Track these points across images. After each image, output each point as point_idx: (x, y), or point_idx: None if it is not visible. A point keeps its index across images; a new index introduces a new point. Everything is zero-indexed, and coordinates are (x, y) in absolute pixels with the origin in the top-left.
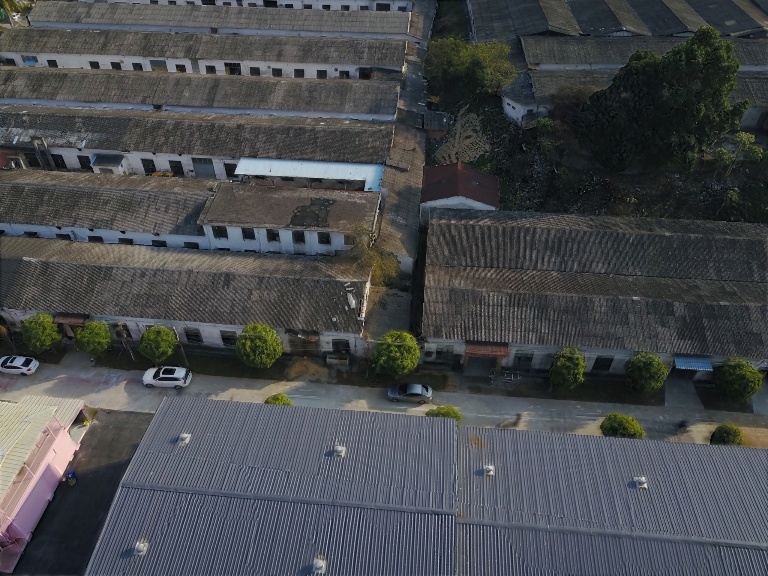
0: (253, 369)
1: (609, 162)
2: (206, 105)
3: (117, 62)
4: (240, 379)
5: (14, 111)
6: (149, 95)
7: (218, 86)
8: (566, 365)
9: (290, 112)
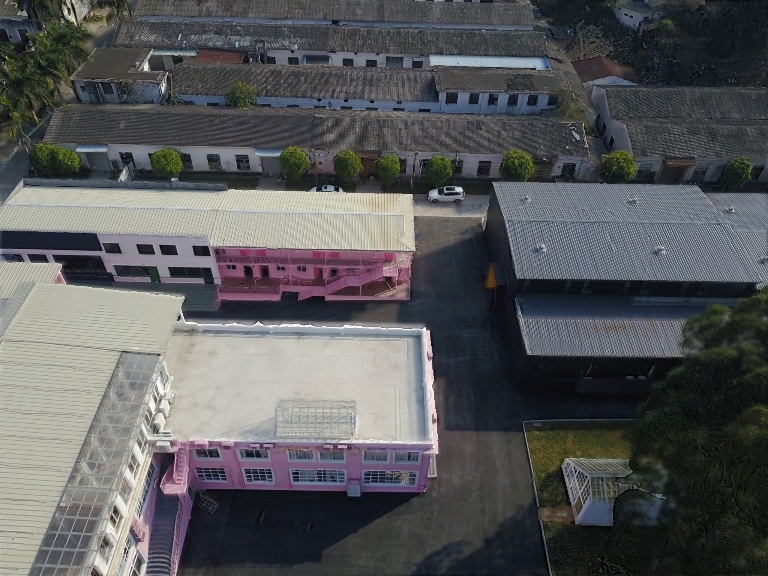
0: None
1: (719, 49)
2: (378, 20)
3: None
4: None
5: None
6: (328, 13)
7: (384, 5)
8: (741, 166)
9: (448, 25)
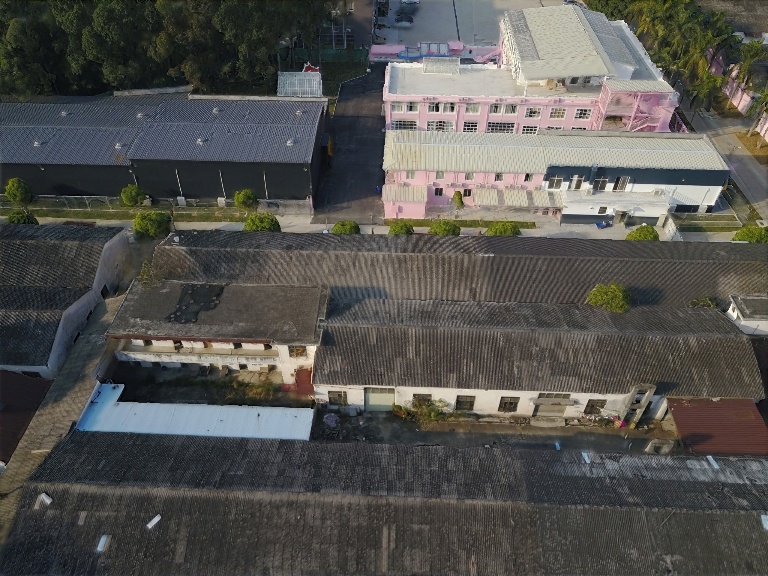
0: None
1: None
2: None
3: None
4: None
5: None
6: None
7: None
8: None
9: None
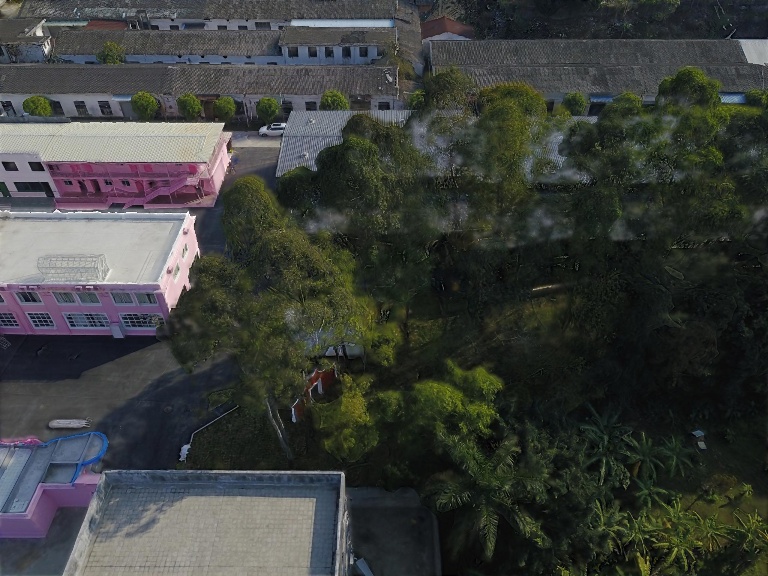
0: None
1: (546, 7)
2: None
3: None
4: None
5: None
6: None
7: None
8: None
9: None
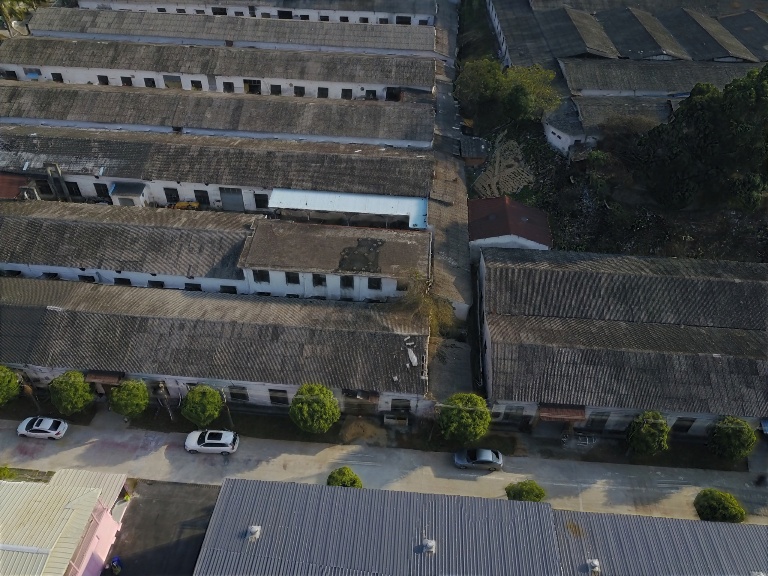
0: (305, 431)
1: (667, 199)
2: (230, 128)
3: (128, 77)
4: (291, 442)
5: (23, 133)
6: (168, 116)
7: (242, 107)
8: (651, 432)
9: (320, 137)
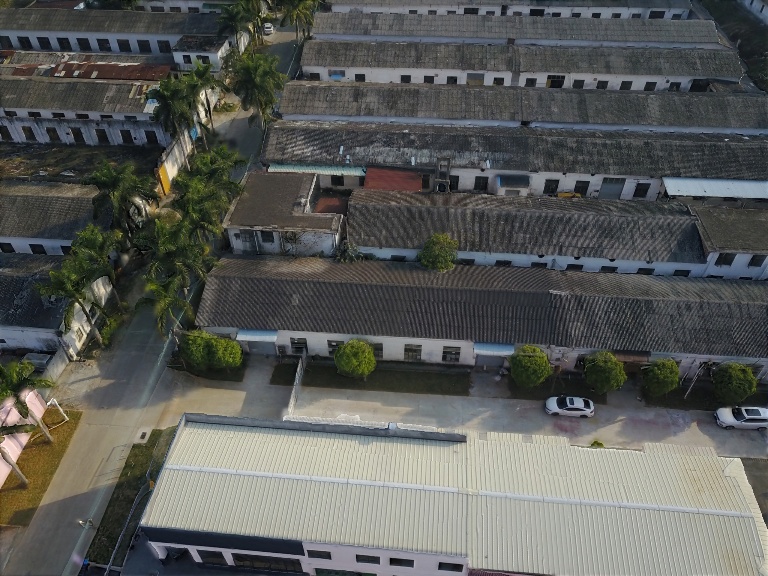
0: None
1: None
2: (581, 121)
3: (431, 76)
4: None
5: (394, 130)
6: (516, 111)
7: (586, 101)
8: None
9: (671, 127)
